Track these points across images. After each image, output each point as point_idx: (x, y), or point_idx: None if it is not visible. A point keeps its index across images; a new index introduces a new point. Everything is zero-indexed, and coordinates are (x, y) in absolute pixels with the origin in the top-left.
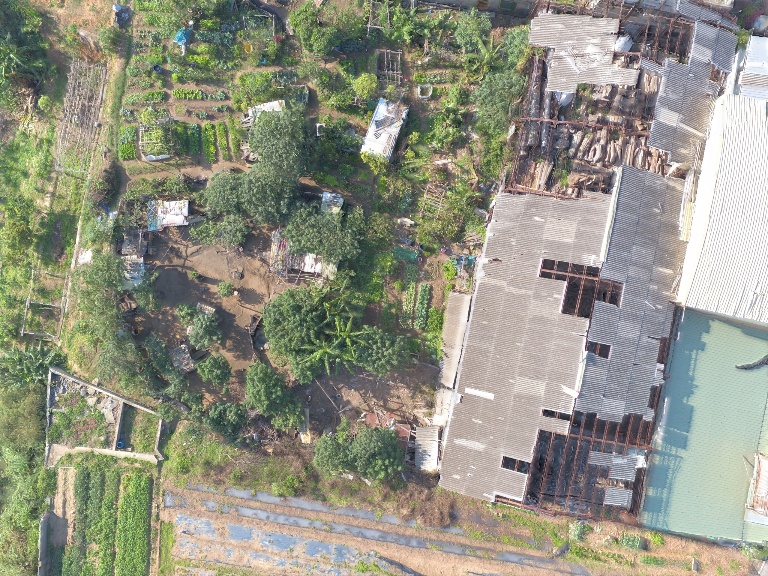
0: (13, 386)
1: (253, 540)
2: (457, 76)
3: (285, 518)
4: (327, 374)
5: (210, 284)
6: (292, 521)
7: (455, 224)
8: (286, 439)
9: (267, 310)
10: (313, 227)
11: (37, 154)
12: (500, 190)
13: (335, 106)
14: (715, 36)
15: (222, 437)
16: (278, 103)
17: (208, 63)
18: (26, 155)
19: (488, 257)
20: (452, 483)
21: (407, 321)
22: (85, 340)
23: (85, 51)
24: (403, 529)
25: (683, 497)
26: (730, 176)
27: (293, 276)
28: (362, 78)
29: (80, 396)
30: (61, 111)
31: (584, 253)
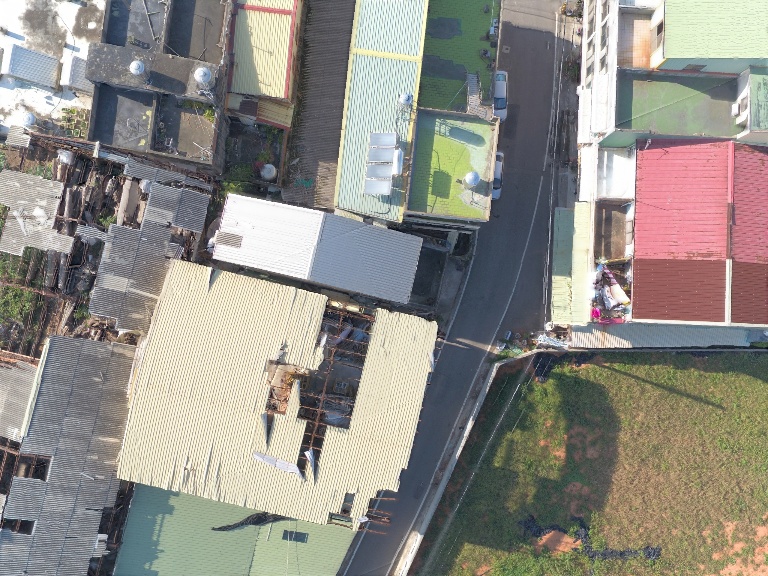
0: None
1: None
2: None
3: None
4: None
5: None
6: None
7: None
8: None
9: None
10: None
11: None
12: None
13: None
14: (177, 198)
15: None
16: None
17: None
18: None
19: None
20: None
21: None
22: None
23: None
24: None
25: None
26: (159, 350)
27: None
28: None
29: None
30: None
31: (9, 426)
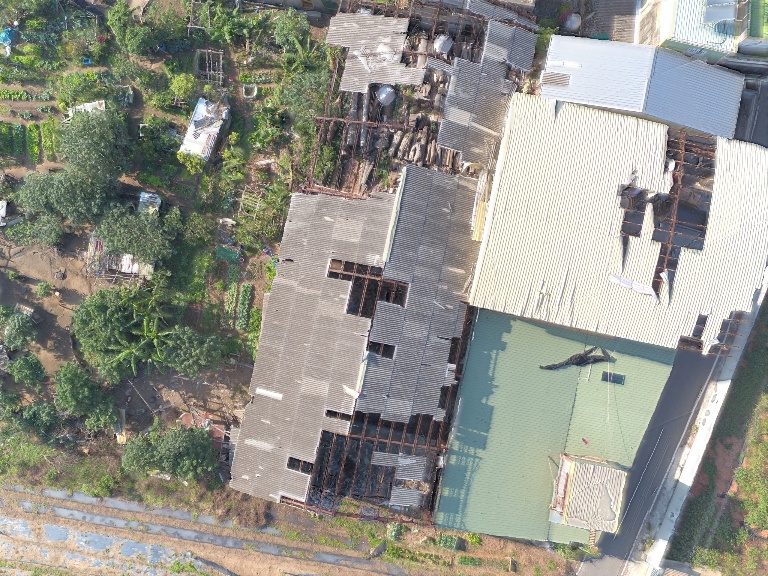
0: None
1: (69, 541)
2: (283, 76)
3: (101, 519)
4: (147, 375)
5: (32, 285)
6: (108, 522)
7: (275, 224)
8: (102, 440)
9: (76, 311)
10: (125, 227)
11: None
12: None
13: (157, 106)
14: (511, 35)
15: (35, 438)
16: (98, 103)
17: (33, 64)
18: None
19: (281, 257)
20: (241, 484)
21: (228, 321)
22: None
23: None
24: (220, 530)
25: (483, 498)
26: (514, 175)
27: (110, 277)
28: (178, 78)
29: None
30: None
31: (368, 253)
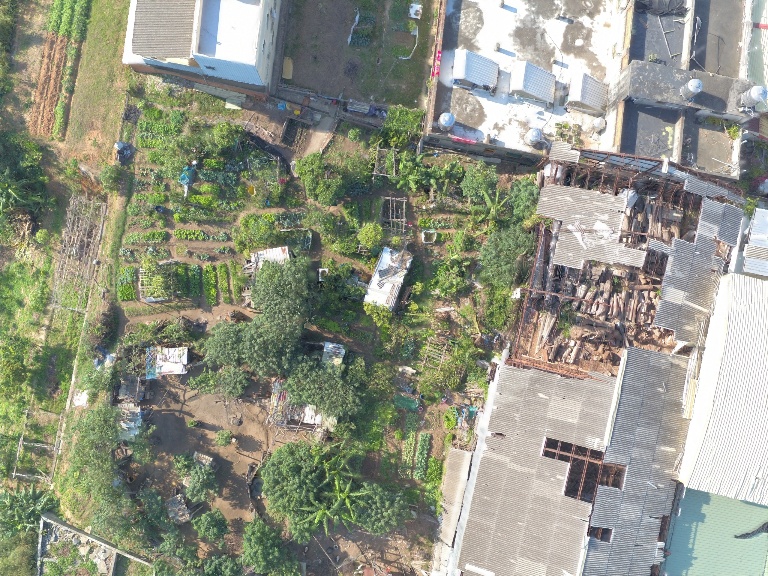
0: (4, 534)
1: None
2: (461, 222)
3: None
4: None
5: (208, 430)
6: None
7: (457, 375)
8: None
9: (266, 468)
10: (314, 382)
11: (33, 284)
12: (504, 353)
13: (338, 252)
14: (721, 212)
15: None
16: (281, 250)
17: (211, 203)
18: (22, 283)
19: (491, 431)
20: None
21: (406, 471)
22: (79, 490)
23: (85, 183)
24: None
25: None
26: (734, 361)
27: (292, 427)
28: (367, 229)
29: (72, 545)
30: (59, 242)
31: (588, 435)
